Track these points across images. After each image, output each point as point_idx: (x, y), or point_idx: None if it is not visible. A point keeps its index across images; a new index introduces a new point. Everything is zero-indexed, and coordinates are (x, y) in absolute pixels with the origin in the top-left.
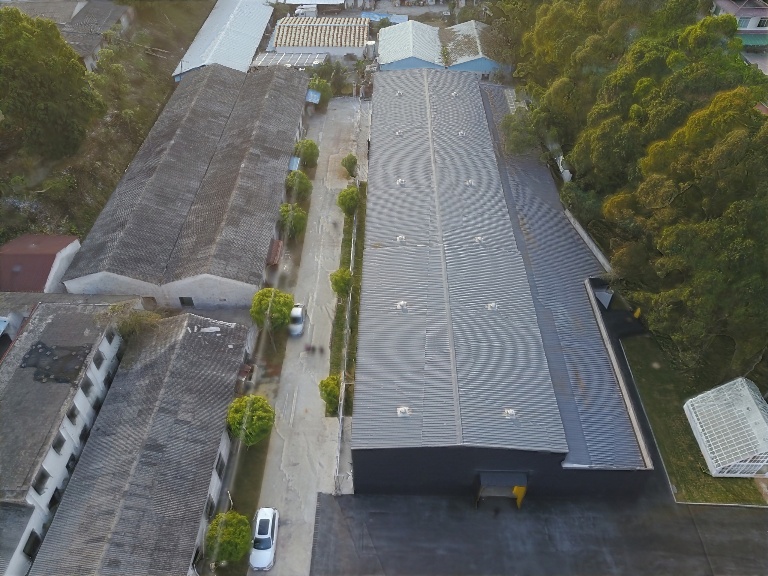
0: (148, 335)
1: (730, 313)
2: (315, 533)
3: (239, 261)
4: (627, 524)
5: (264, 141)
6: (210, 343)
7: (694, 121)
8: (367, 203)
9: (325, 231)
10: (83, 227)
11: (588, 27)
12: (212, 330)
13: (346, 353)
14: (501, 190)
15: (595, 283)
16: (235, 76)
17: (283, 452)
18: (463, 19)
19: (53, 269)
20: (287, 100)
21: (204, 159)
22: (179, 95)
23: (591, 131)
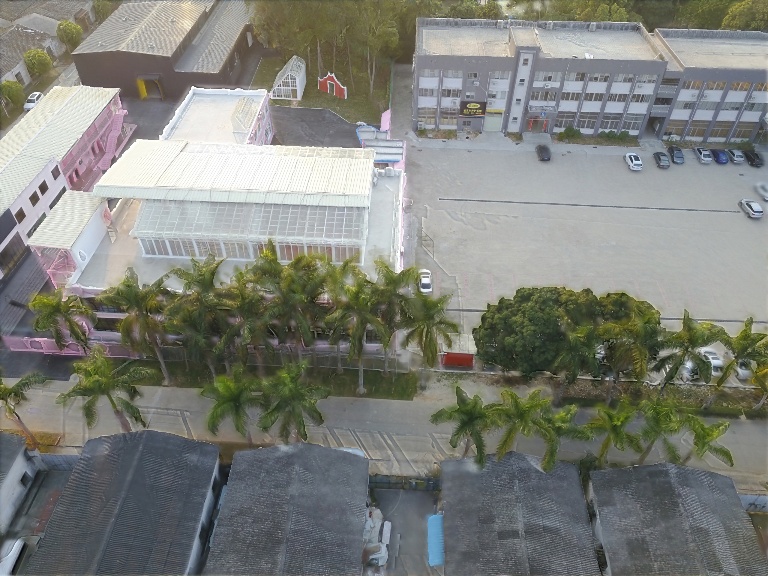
0: None
1: None
2: None
3: (57, 12)
4: None
5: None
6: (26, 35)
7: None
8: None
9: None
10: None
11: None
12: (29, 31)
13: None
14: None
15: (248, 25)
16: None
17: (58, 85)
18: None
19: None
20: None
21: None
22: None
23: None
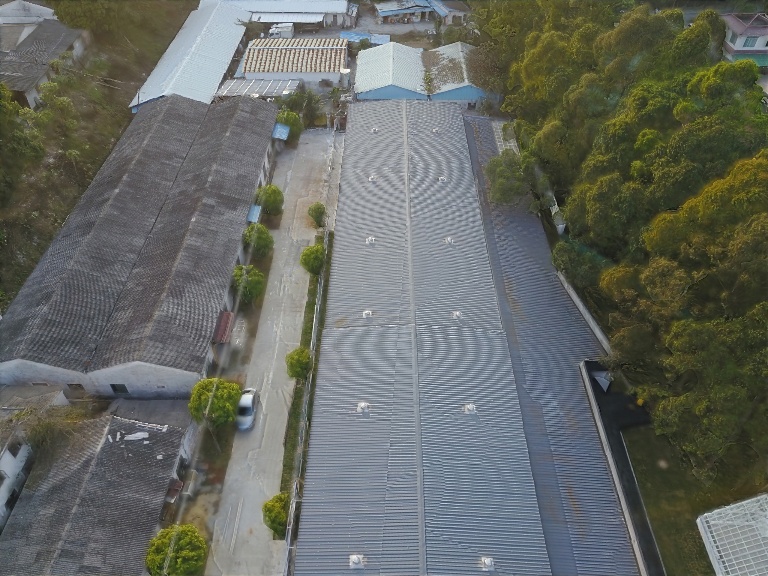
0: (62, 443)
1: (757, 438)
2: None
3: (179, 342)
4: None
5: (221, 188)
6: (134, 455)
7: (710, 196)
8: (331, 267)
9: (287, 293)
10: (12, 291)
11: (582, 63)
12: (138, 437)
13: (302, 453)
14: (485, 250)
15: (592, 368)
16: (196, 108)
17: None
18: (449, 40)
19: None
20: (251, 137)
21: (152, 210)
22: (132, 132)
23: (586, 187)
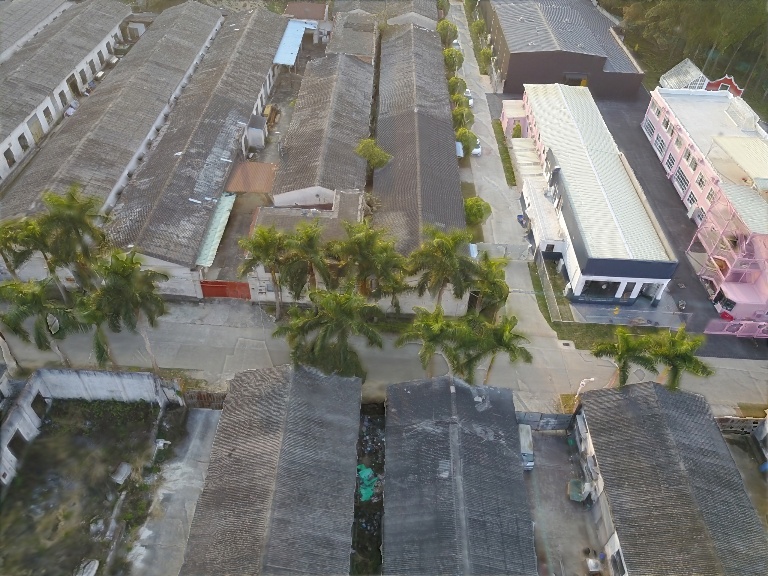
0: (392, 31)
1: (681, 4)
2: (488, 102)
3: (426, 12)
4: (631, 106)
5: None
6: (425, 33)
7: None
8: None
9: (457, 20)
10: None
11: None
12: (425, 29)
13: None
14: None
15: (615, 28)
16: None
17: None
18: None
19: (325, 12)
20: None
21: None
22: None
23: None
